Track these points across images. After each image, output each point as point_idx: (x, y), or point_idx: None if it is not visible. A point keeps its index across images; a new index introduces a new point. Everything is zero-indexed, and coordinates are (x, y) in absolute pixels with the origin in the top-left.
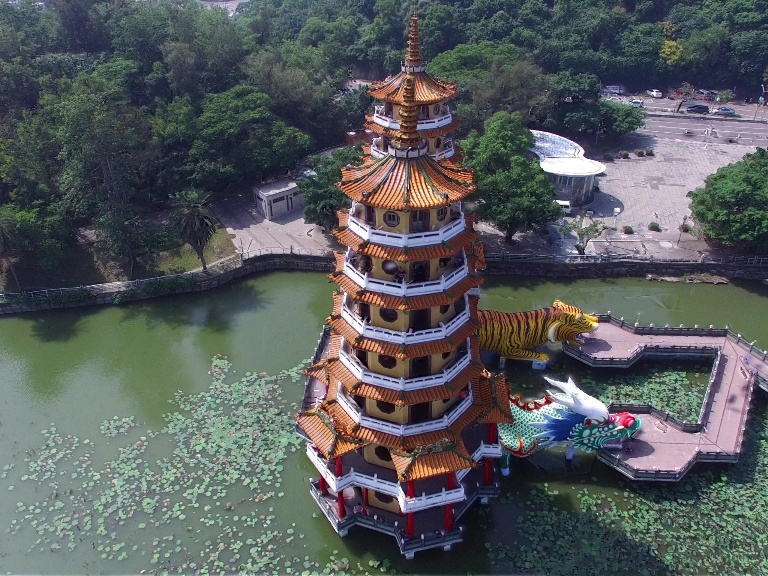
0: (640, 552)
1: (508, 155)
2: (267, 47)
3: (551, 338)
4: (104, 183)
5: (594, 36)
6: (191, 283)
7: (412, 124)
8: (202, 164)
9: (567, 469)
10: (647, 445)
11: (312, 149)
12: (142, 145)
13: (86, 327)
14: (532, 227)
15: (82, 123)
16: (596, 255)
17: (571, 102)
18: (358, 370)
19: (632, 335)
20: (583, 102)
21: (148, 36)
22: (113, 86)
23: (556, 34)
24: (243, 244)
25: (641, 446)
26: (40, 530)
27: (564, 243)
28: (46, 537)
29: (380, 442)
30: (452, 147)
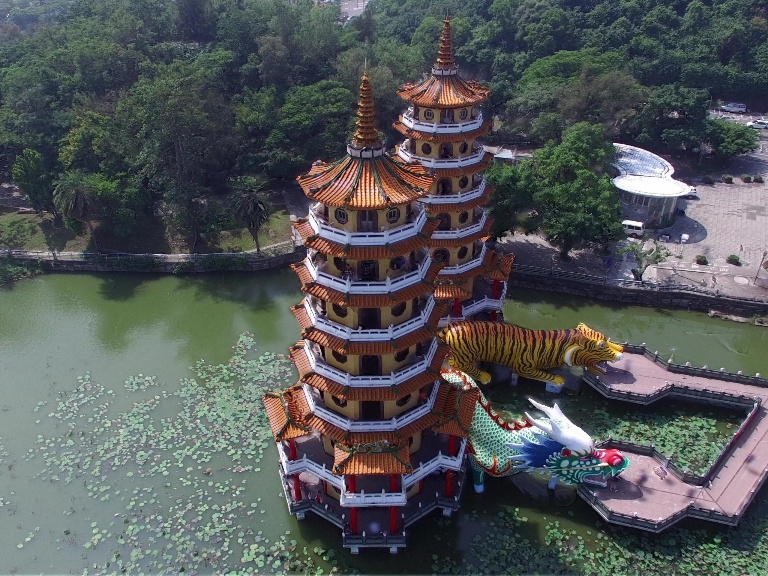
0: None
1: (579, 168)
2: None
3: (567, 361)
4: (177, 162)
5: (725, 48)
6: (243, 262)
7: (368, 125)
8: (275, 152)
9: (550, 498)
10: (636, 489)
11: (392, 146)
12: (227, 130)
13: (144, 291)
14: (589, 245)
15: (158, 106)
16: (654, 282)
17: (677, 118)
18: (313, 360)
19: (664, 371)
20: (689, 119)
21: (248, 29)
22: (209, 74)
23: (681, 44)
24: None
25: (629, 488)
26: (48, 462)
27: (624, 266)
28: (51, 468)
29: (327, 433)
30: (479, 153)
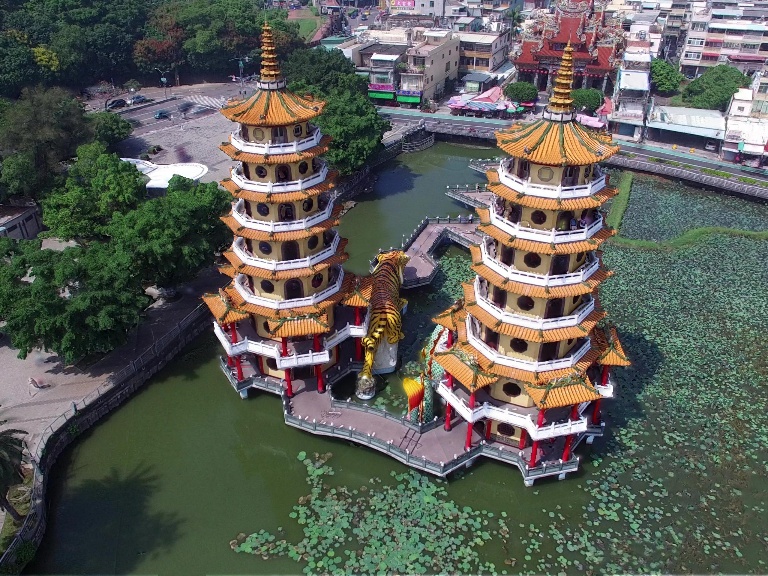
0: None
1: (145, 184)
2: None
3: None
4: None
5: None
6: (31, 547)
7: None
8: None
9: None
10: None
11: None
12: None
13: None
14: None
15: None
16: None
17: None
18: (572, 319)
19: None
20: None
21: None
22: None
23: None
24: None
25: None
26: None
27: None
28: None
29: (592, 361)
30: None
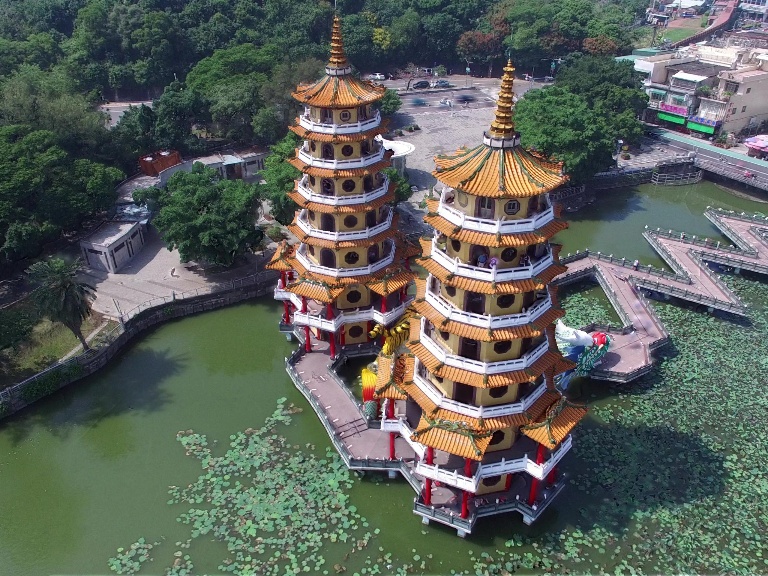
0: (664, 433)
1: None
2: (0, 77)
3: None
4: None
5: (313, 30)
6: (79, 369)
7: None
8: (14, 228)
9: None
10: (613, 354)
11: None
12: None
13: None
14: None
15: None
16: None
17: None
18: (479, 365)
19: None
20: None
21: None
22: None
23: (277, 32)
24: (107, 307)
25: (610, 356)
26: None
27: (417, 218)
28: None
29: (510, 425)
30: None
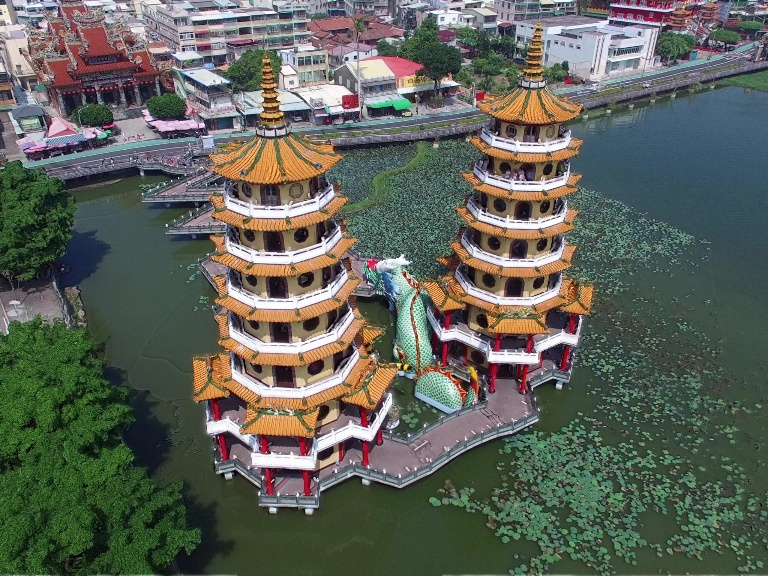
0: None
1: None
2: None
3: None
4: None
5: None
6: None
7: None
8: None
9: None
10: None
11: None
12: None
13: None
14: None
15: None
16: None
17: None
18: None
19: None
20: None
21: None
22: None
23: None
24: None
25: None
26: None
27: None
28: None
29: None
30: None
